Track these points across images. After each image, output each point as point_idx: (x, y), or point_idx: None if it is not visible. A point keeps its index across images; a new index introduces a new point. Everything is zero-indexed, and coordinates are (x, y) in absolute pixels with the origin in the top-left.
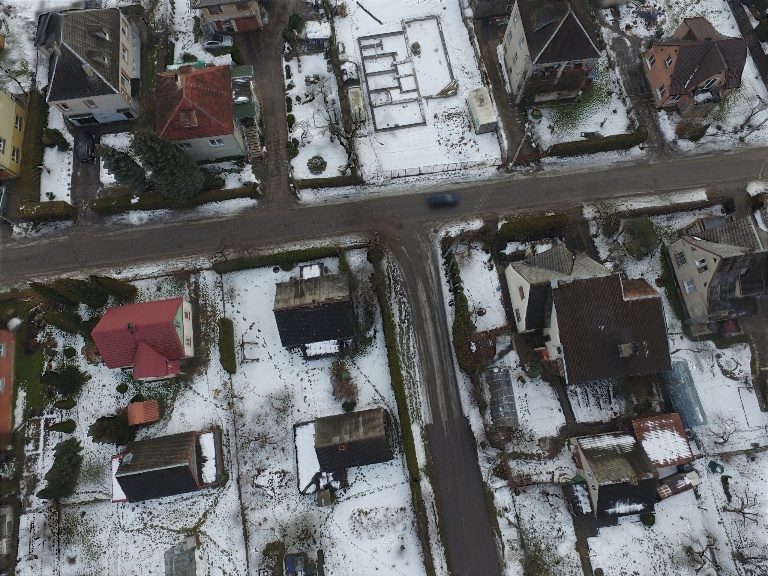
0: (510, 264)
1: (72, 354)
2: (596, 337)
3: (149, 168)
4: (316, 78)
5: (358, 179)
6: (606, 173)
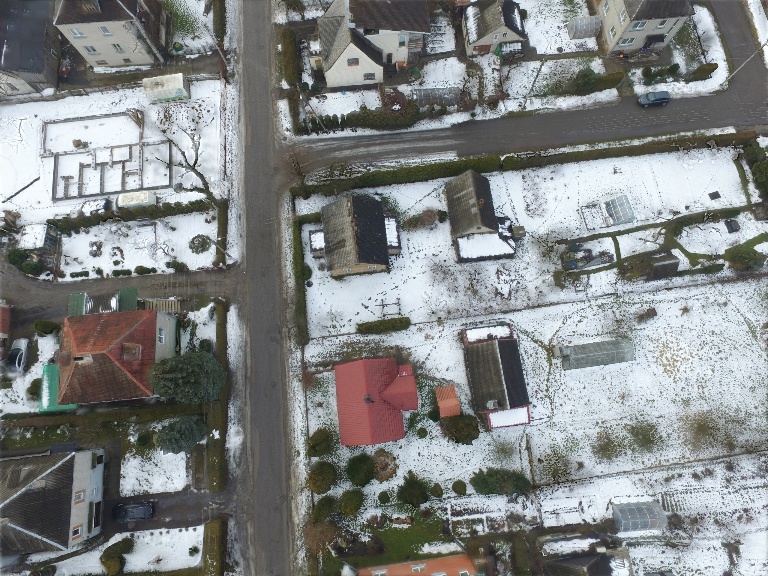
0: (325, 74)
1: (386, 494)
2: (396, 7)
3: (189, 389)
4: (94, 244)
5: (223, 202)
6: (246, 3)
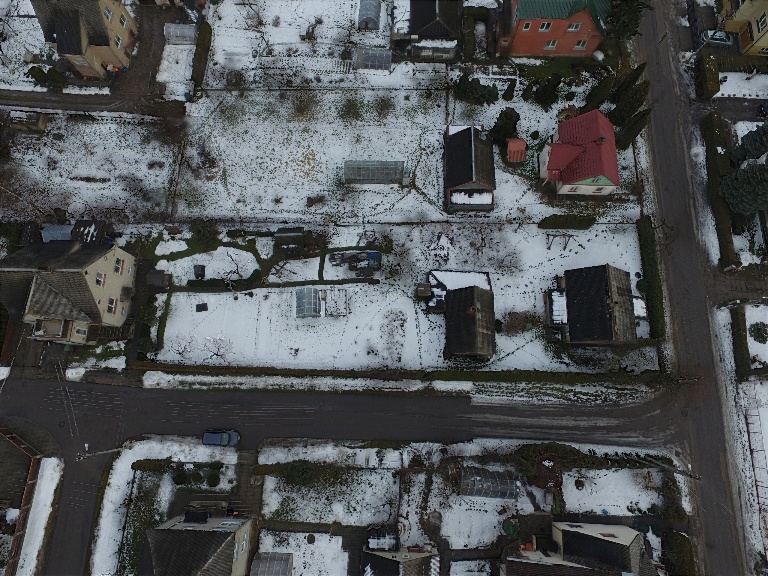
0: None
1: (569, 98)
2: None
3: None
4: None
5: (745, 375)
6: None
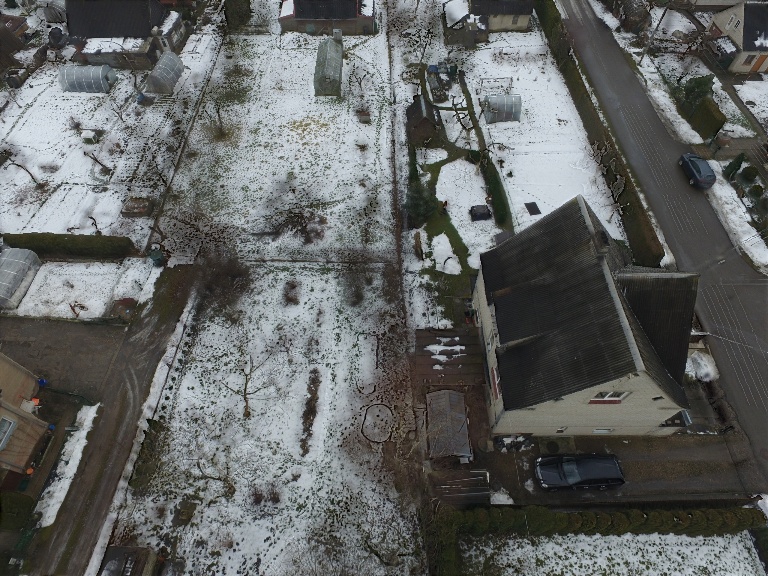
0: None
1: None
2: None
3: None
4: None
5: None
6: None
